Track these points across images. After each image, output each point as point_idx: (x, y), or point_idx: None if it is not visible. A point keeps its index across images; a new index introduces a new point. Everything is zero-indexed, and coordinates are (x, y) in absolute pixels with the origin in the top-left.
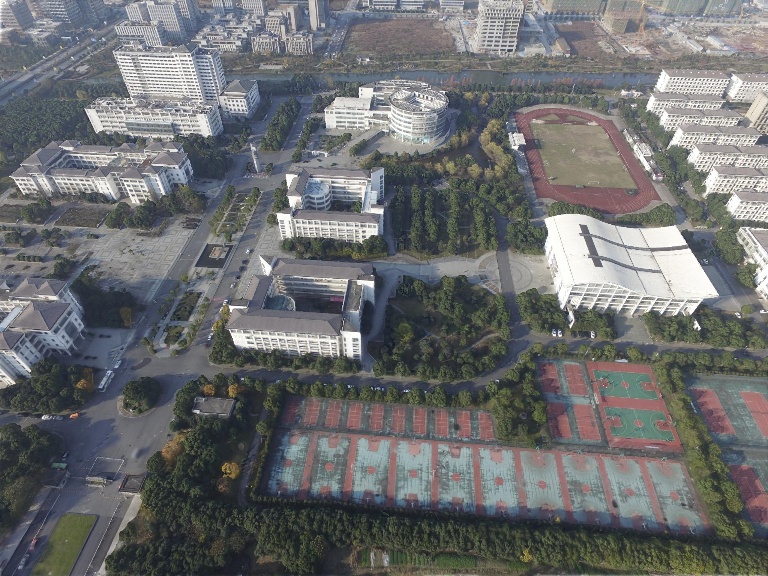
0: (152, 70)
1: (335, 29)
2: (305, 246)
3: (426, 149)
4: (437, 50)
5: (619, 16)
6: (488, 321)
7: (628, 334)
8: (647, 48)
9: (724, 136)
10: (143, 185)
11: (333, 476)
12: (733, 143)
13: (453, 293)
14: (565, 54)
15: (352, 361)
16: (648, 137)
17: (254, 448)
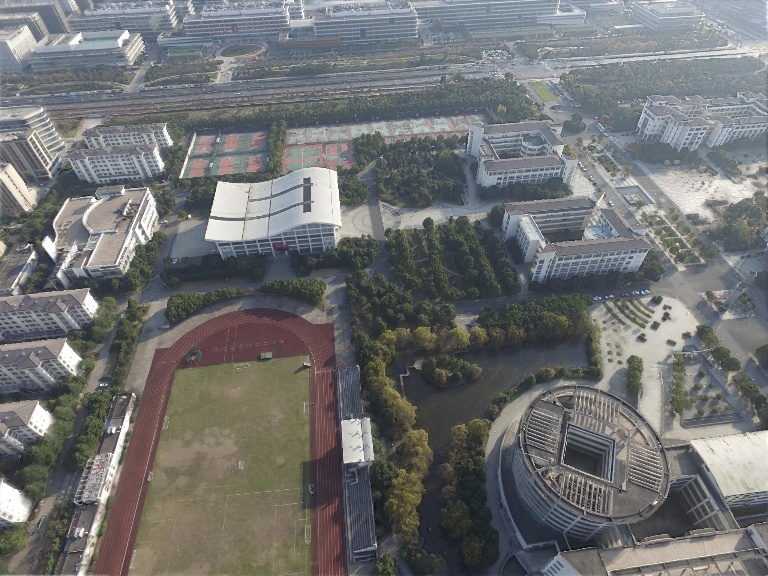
0: None
1: None
2: None
3: None
4: None
5: None
6: None
7: None
8: None
9: None
10: None
11: (456, 120)
12: None
13: None
14: None
15: None
16: None
17: None
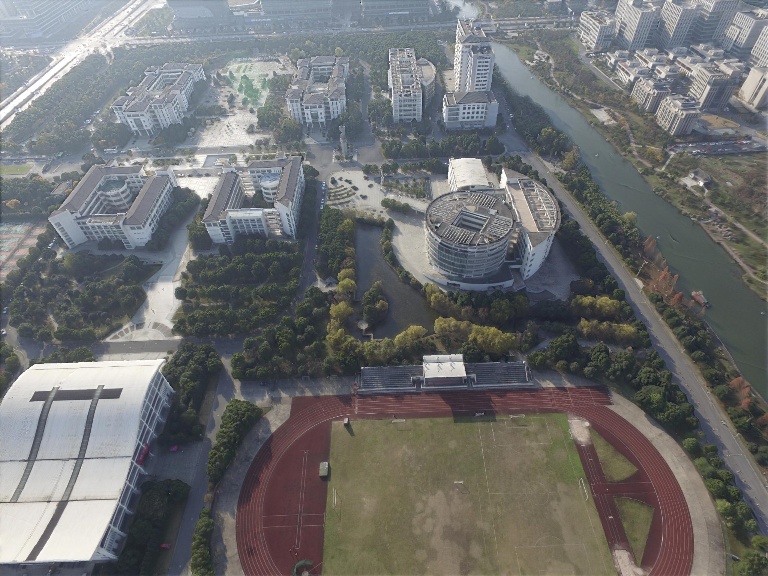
0: None
1: None
2: None
3: (417, 267)
4: None
5: None
6: None
7: None
8: None
9: None
10: None
11: None
12: None
13: None
14: None
15: None
16: None
17: None
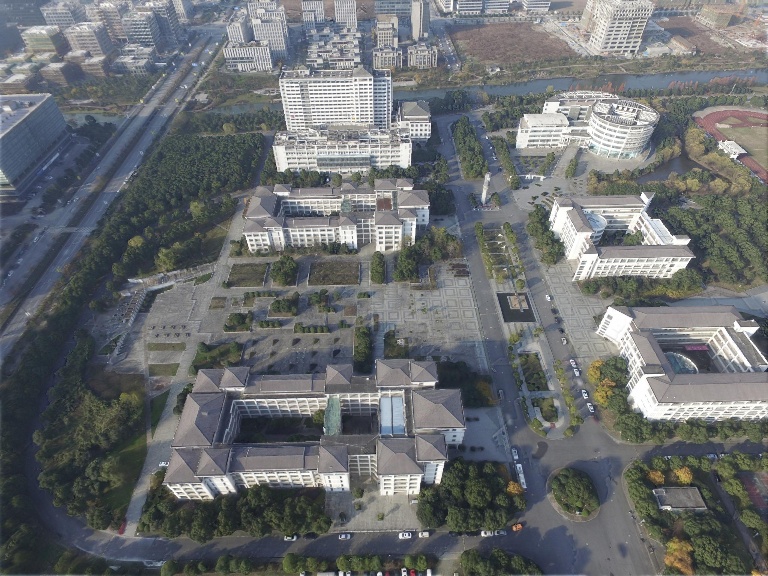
0: (320, 97)
1: (437, 38)
2: (613, 287)
3: (637, 164)
4: (560, 55)
5: (722, 10)
6: None
7: None
8: (761, 41)
9: None
10: (398, 231)
11: None
12: None
13: None
14: (691, 52)
15: None
16: None
17: None
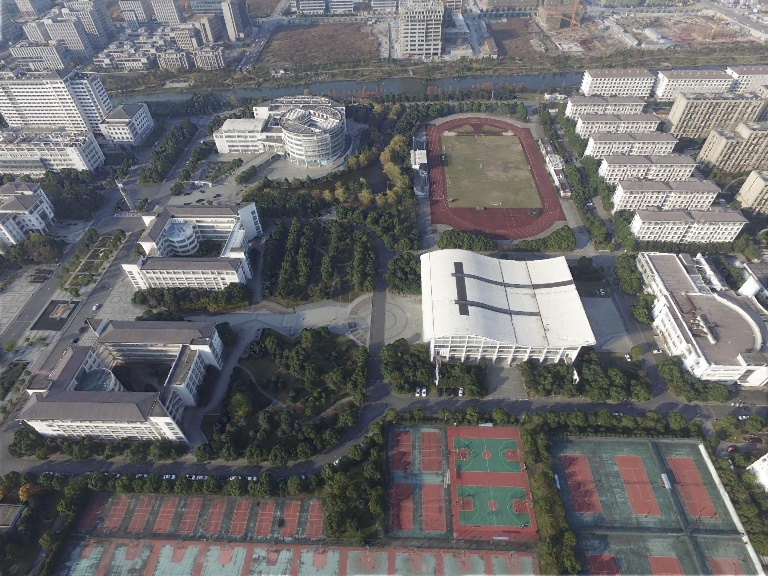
0: (27, 99)
1: (255, 38)
2: (157, 299)
3: (322, 172)
4: (358, 57)
5: (552, 11)
6: (343, 383)
7: (501, 389)
8: (581, 44)
9: (638, 144)
10: None
11: None
12: (649, 151)
13: (312, 348)
14: (492, 55)
15: (177, 443)
16: (564, 146)
17: (36, 566)
